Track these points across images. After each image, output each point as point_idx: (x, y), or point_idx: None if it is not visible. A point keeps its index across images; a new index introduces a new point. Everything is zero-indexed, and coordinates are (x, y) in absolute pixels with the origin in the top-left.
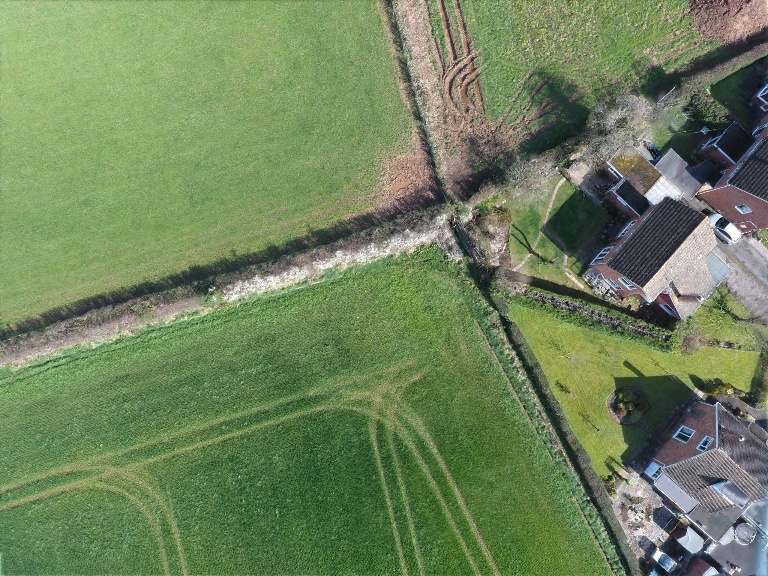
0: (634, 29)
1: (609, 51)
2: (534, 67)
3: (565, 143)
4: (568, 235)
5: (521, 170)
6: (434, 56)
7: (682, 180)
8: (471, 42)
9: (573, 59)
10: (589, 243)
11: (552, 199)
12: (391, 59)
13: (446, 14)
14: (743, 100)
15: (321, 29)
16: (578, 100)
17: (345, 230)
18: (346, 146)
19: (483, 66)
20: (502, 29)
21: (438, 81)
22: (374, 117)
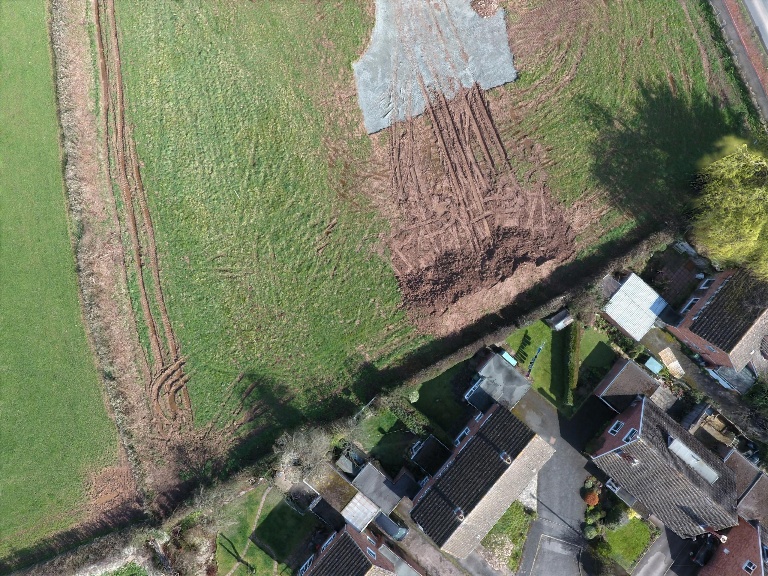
0: (346, 325)
1: (321, 349)
2: (244, 370)
3: (262, 461)
4: (277, 542)
5: (202, 507)
6: (139, 366)
7: (380, 494)
8: (178, 349)
9: (284, 359)
10: (299, 548)
11: (260, 506)
12: (95, 371)
13: (153, 321)
14: (455, 396)
15: (24, 343)
16: (289, 401)
17: (49, 548)
18: (50, 462)
19: (191, 371)
20: (211, 333)
21: (145, 390)
22: (78, 431)
